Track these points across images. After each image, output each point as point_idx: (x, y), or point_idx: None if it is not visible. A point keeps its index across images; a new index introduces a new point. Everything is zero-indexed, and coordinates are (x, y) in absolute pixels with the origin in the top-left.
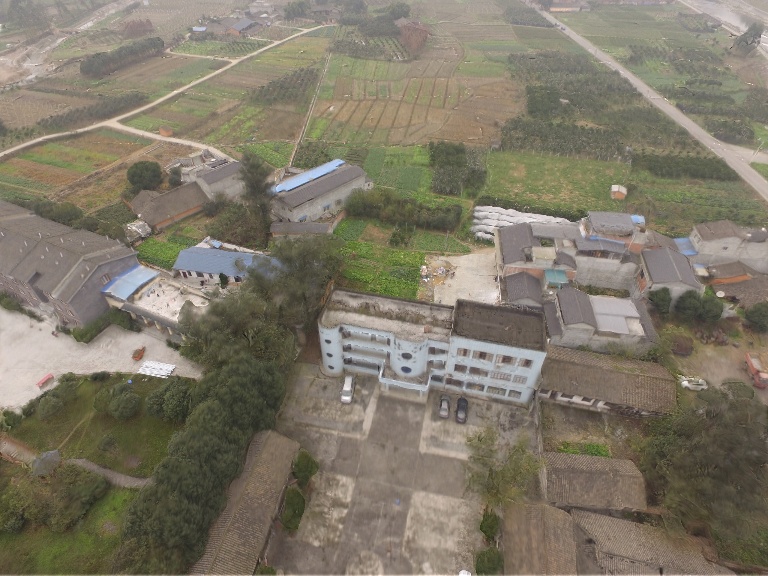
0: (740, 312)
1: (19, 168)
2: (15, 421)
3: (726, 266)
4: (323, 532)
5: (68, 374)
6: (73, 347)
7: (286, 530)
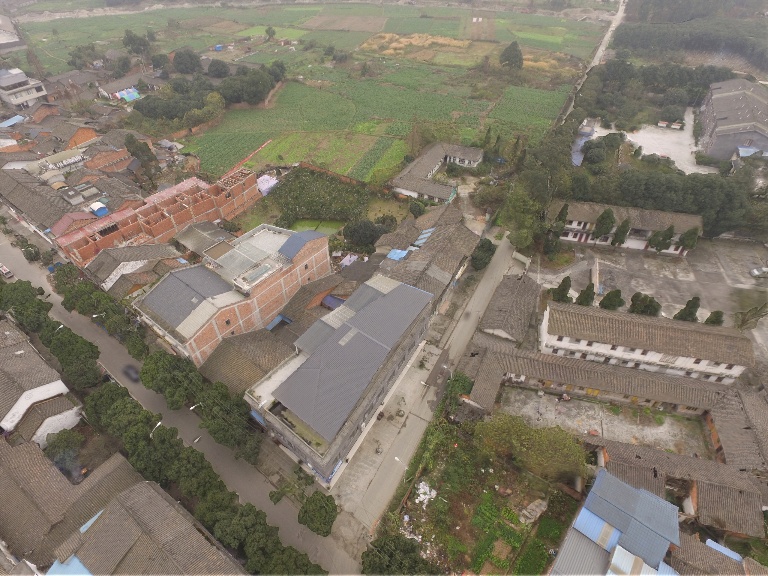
0: None
1: None
2: (638, 153)
3: None
4: (654, 268)
5: (673, 160)
6: (690, 161)
7: (645, 254)
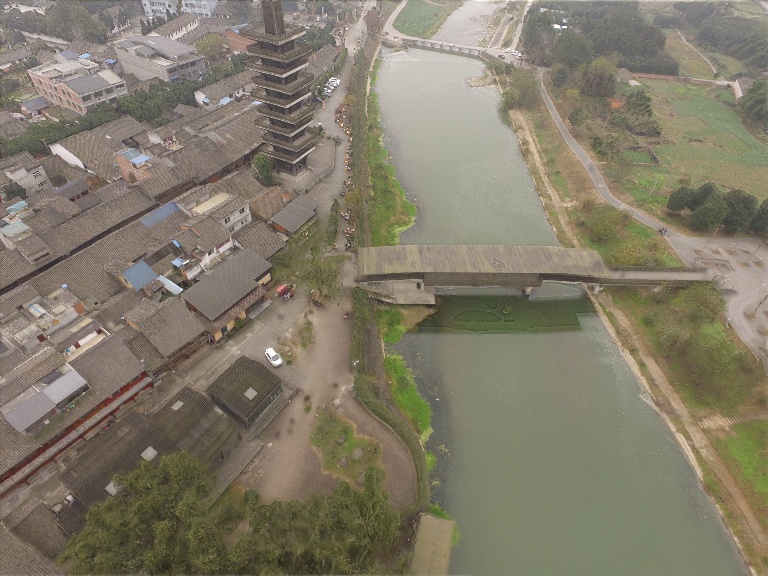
0: None
1: None
2: None
3: None
4: None
5: None
6: None
7: (122, 31)
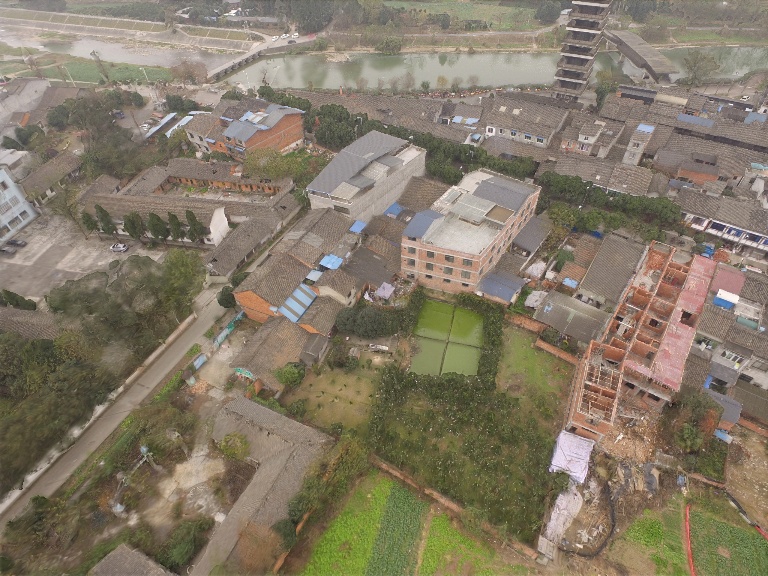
0: (48, 128)
1: None
2: None
3: (12, 119)
4: None
5: None
6: None
7: None
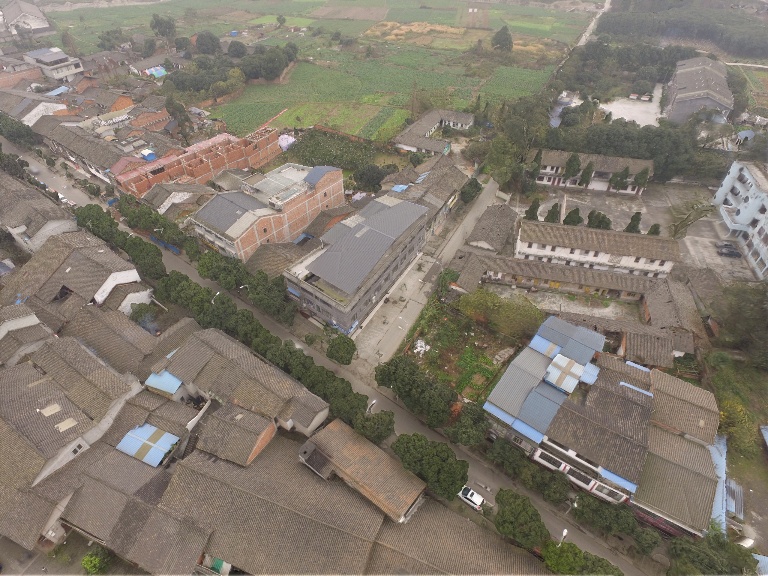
0: None
1: (767, 77)
2: (608, 118)
3: None
4: (613, 204)
5: (639, 124)
6: None
7: (608, 194)
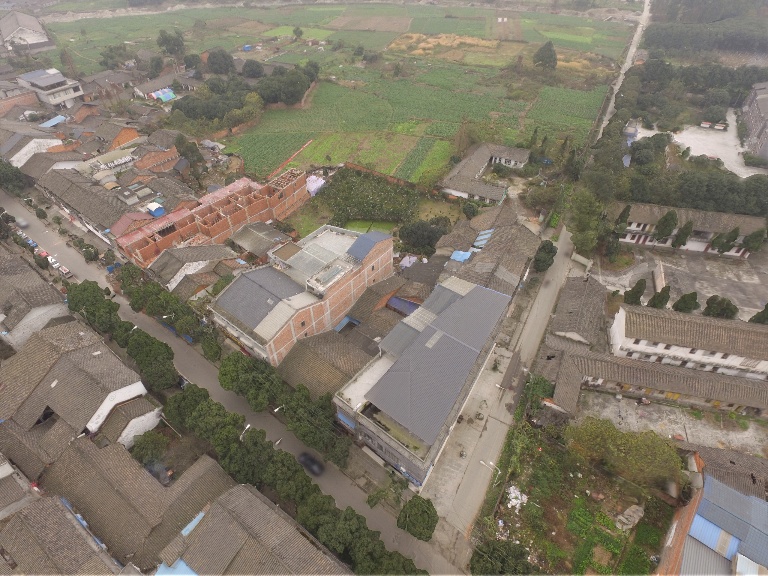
0: None
1: None
2: (686, 154)
3: None
4: (716, 271)
5: None
6: (738, 162)
7: (706, 256)
